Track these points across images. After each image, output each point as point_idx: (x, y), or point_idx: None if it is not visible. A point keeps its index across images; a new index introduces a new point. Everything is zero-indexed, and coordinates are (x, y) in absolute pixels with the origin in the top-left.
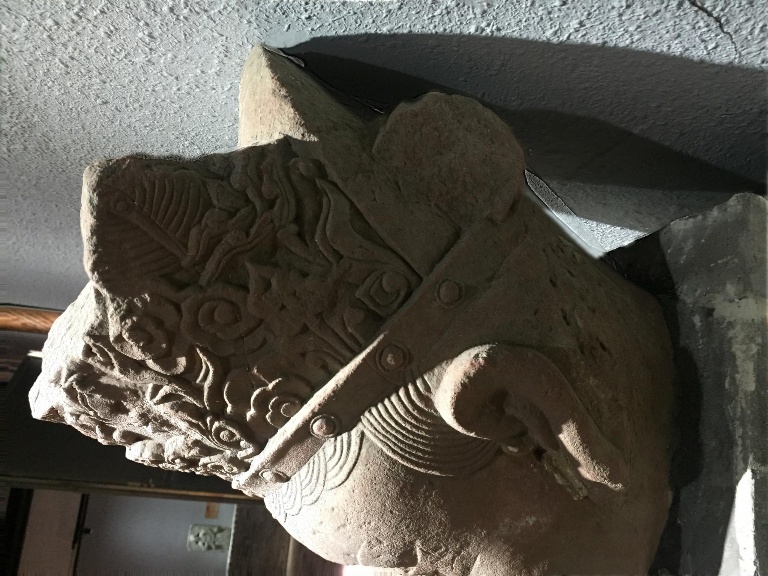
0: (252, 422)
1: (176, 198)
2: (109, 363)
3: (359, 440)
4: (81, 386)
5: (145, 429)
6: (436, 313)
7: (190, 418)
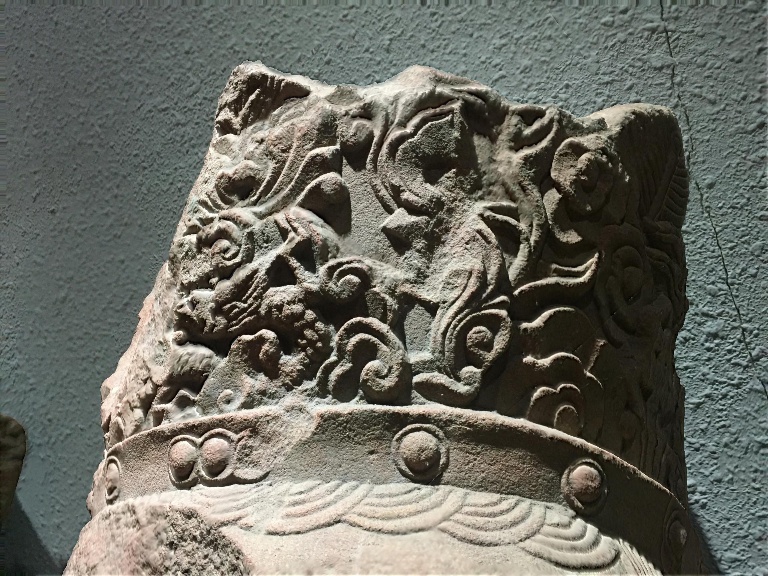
0: (523, 369)
1: (681, 201)
2: (520, 143)
3: (615, 554)
4: (463, 110)
5: (383, 217)
6: (696, 575)
7: (495, 269)
